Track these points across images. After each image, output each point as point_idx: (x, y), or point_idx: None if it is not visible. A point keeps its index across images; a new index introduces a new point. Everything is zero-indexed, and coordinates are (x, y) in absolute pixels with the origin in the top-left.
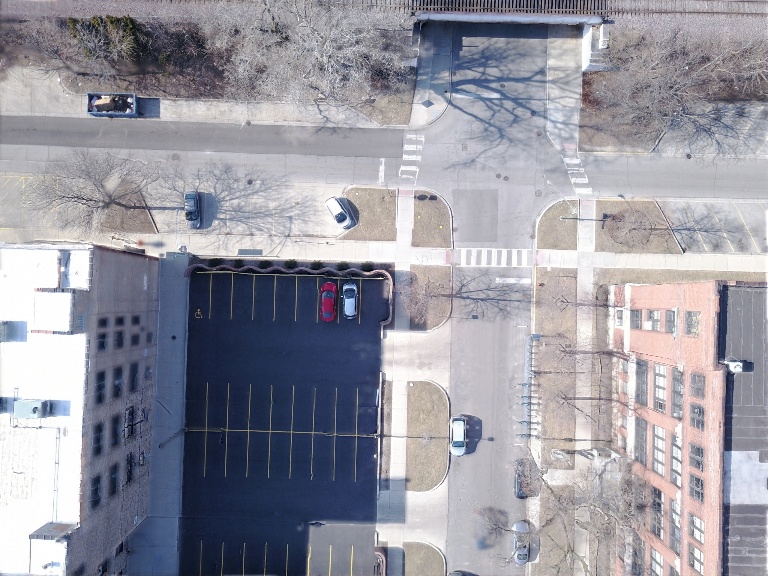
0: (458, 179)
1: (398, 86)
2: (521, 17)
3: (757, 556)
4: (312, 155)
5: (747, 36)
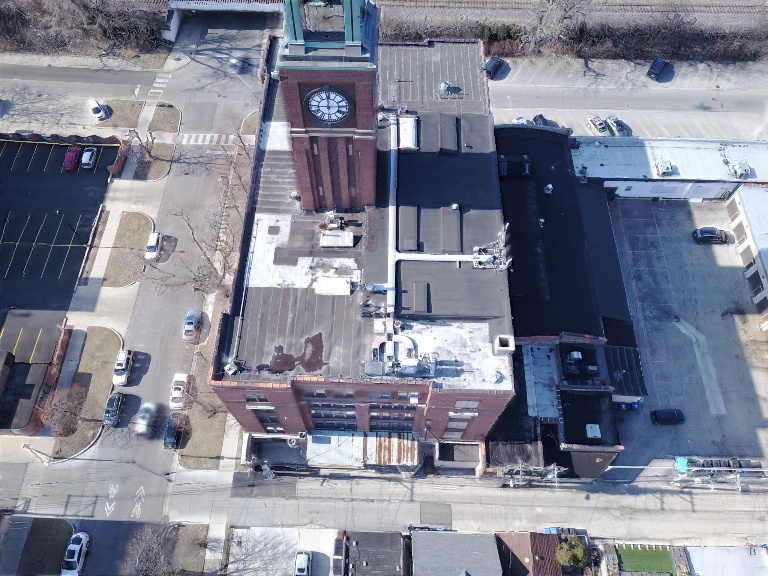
0: (190, 97)
1: (159, 50)
2: (235, 6)
3: (282, 180)
4: (89, 83)
5: (382, 17)
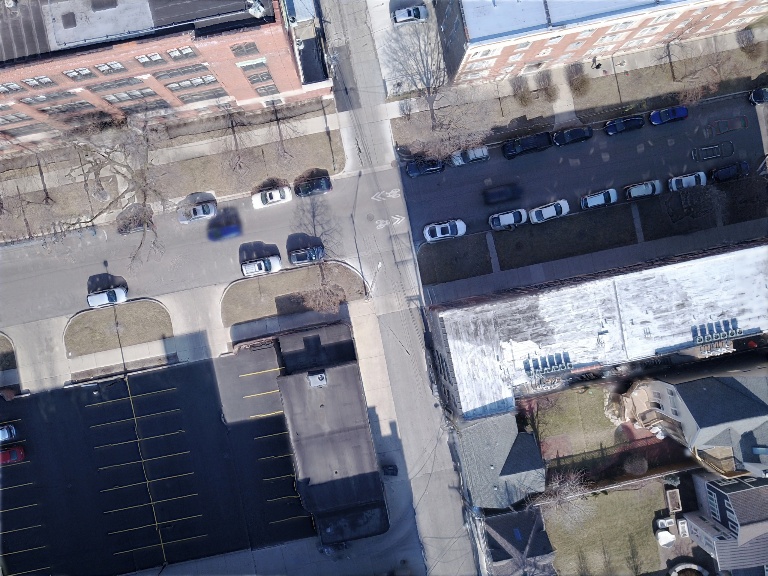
0: None
1: None
2: None
3: None
4: None
5: None
